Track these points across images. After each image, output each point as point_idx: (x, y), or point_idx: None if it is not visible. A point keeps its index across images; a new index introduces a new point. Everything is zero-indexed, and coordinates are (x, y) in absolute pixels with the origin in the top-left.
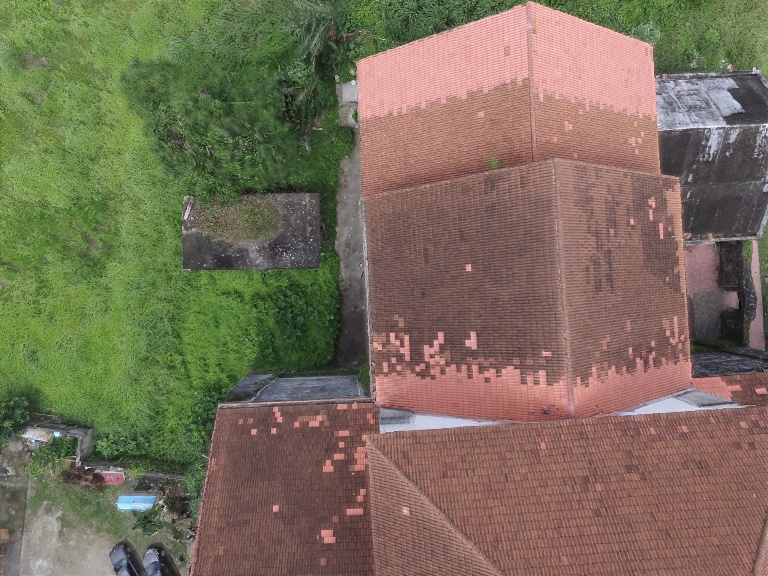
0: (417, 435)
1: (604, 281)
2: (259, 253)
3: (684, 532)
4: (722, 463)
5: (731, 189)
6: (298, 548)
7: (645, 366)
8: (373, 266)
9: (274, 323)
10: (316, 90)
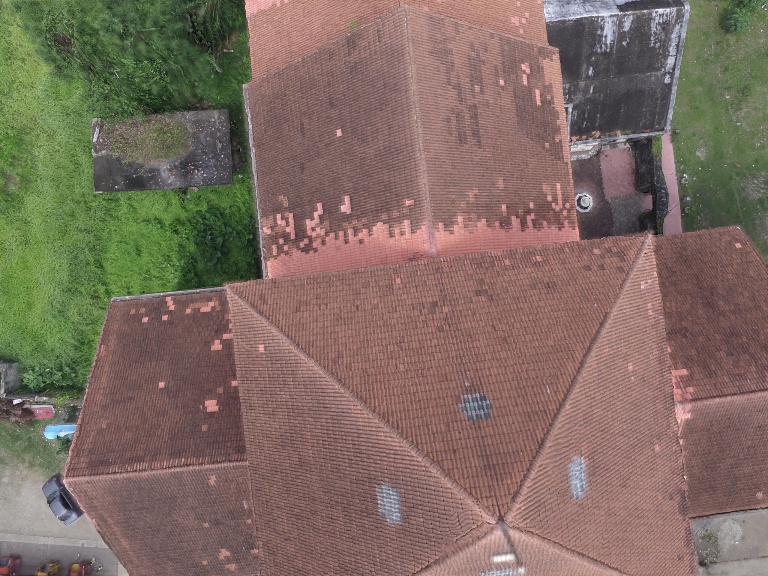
0: (276, 281)
1: (470, 135)
2: (171, 172)
3: (521, 337)
4: (569, 282)
5: (633, 82)
6: (181, 418)
7: (522, 225)
8: (259, 151)
9: (195, 247)
10: (222, 9)
